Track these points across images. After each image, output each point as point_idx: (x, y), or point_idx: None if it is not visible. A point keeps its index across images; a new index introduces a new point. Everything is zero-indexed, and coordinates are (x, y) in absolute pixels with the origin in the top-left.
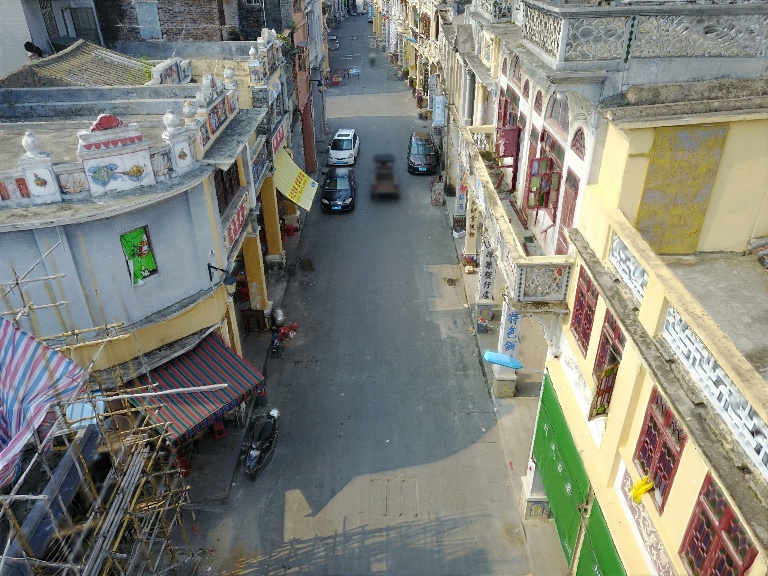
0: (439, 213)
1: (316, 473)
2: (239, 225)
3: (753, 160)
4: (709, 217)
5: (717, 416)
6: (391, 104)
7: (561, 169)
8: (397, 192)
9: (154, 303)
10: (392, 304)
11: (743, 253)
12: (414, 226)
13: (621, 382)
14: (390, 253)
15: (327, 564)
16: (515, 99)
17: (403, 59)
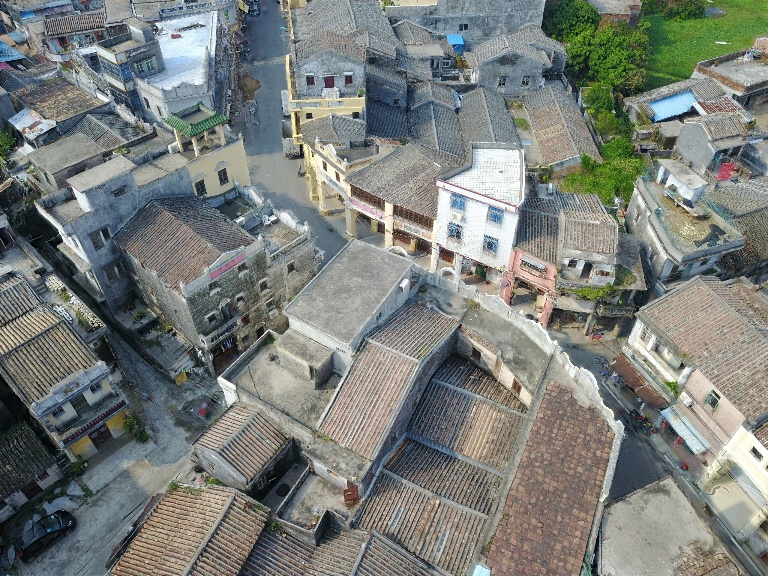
0: None
1: None
2: None
3: None
4: None
5: None
6: None
7: None
8: (273, 10)
9: (229, 24)
10: (272, 36)
11: None
12: (278, 19)
13: None
14: (271, 26)
15: None
16: None
17: None
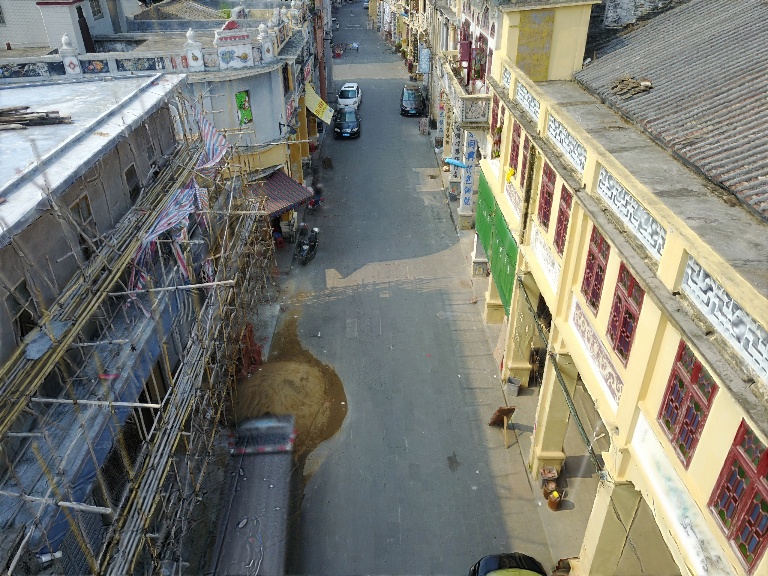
0: (425, 140)
1: (344, 262)
2: (290, 113)
3: (569, 28)
4: (552, 60)
5: (527, 112)
6: (386, 70)
7: (487, 51)
8: (392, 127)
9: (249, 141)
10: (390, 188)
11: (571, 81)
12: (406, 147)
13: (503, 132)
14: (388, 161)
15: (354, 295)
16: (469, 25)
17: (396, 35)
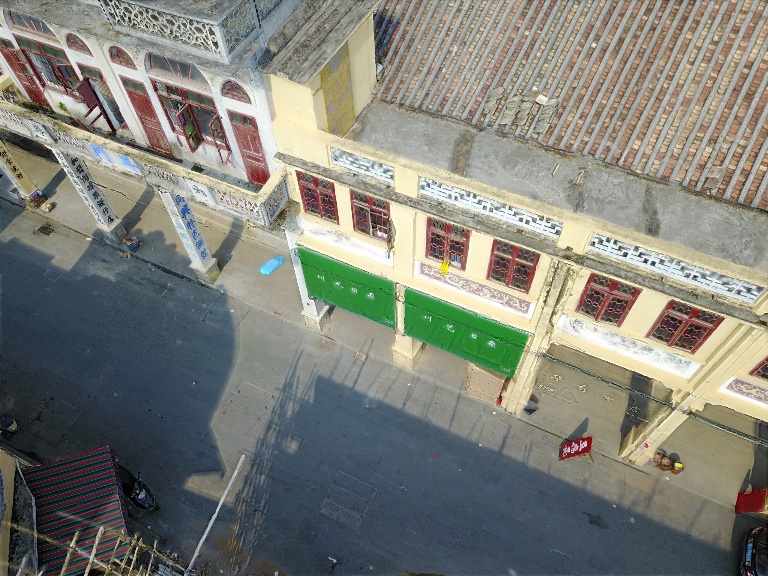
0: None
1: (186, 453)
2: None
3: (360, 49)
4: (354, 96)
5: (488, 217)
6: None
7: (214, 111)
8: None
9: None
10: (31, 295)
11: (372, 101)
12: None
13: (401, 228)
14: None
15: (273, 478)
16: (49, 50)
17: None
